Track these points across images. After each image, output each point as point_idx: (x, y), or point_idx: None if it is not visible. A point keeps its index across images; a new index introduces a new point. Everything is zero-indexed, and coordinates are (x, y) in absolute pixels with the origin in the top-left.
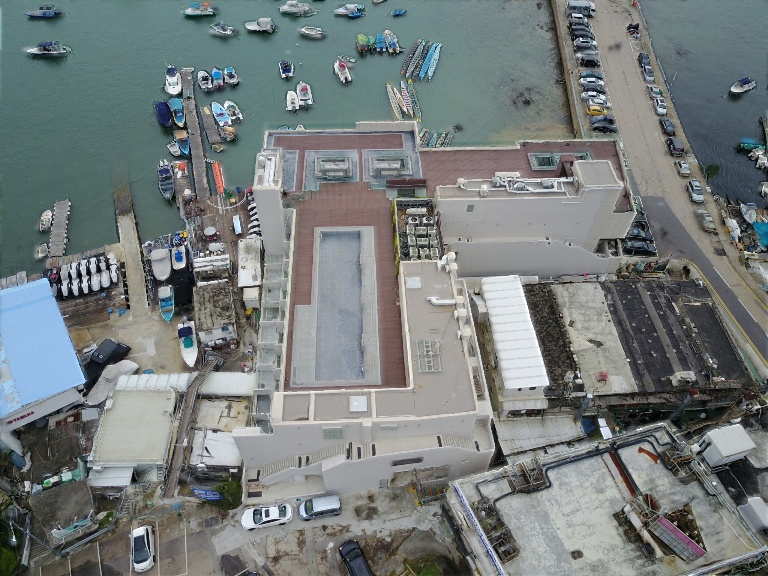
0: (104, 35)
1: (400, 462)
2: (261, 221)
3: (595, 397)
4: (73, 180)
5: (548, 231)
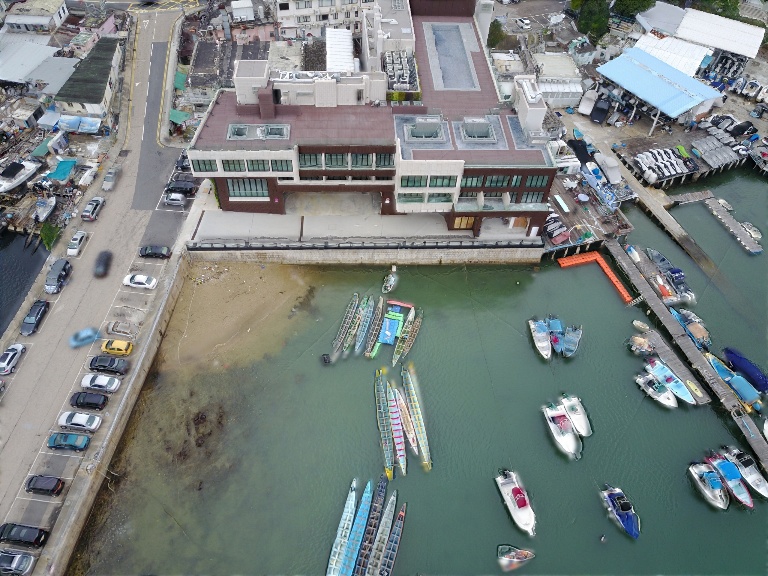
0: None
1: None
2: None
3: None
4: None
5: None
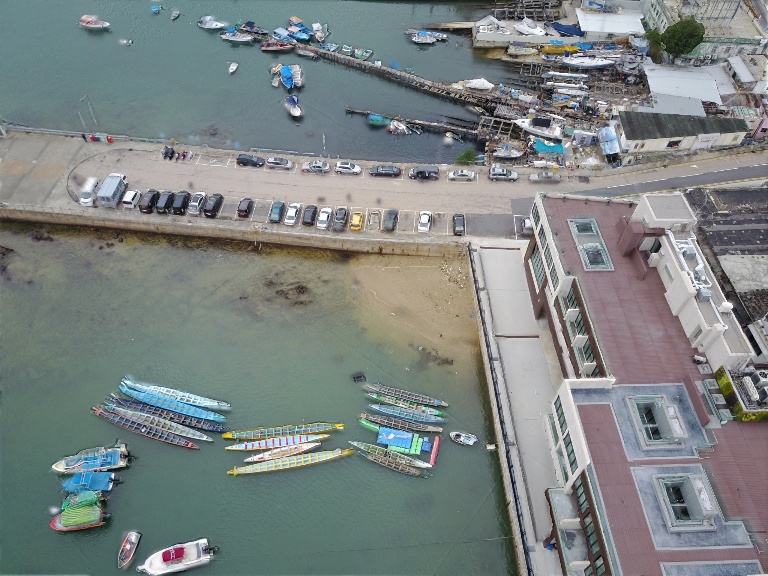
0: None
1: None
2: None
3: None
4: None
5: None
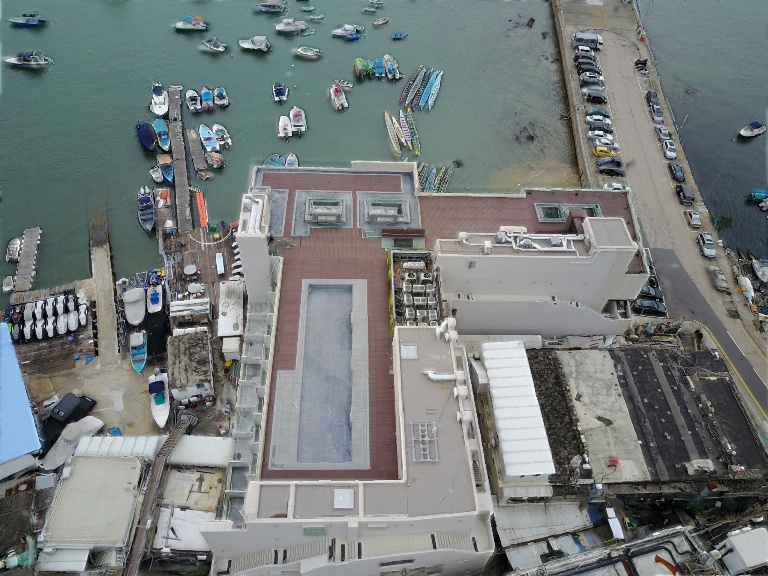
0: (90, 46)
1: (388, 562)
2: (245, 268)
3: (604, 485)
4: (46, 205)
5: (554, 290)
